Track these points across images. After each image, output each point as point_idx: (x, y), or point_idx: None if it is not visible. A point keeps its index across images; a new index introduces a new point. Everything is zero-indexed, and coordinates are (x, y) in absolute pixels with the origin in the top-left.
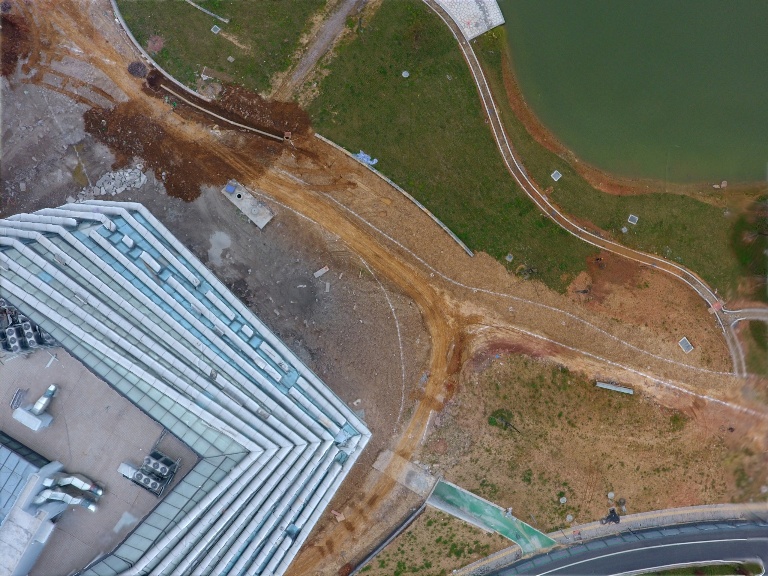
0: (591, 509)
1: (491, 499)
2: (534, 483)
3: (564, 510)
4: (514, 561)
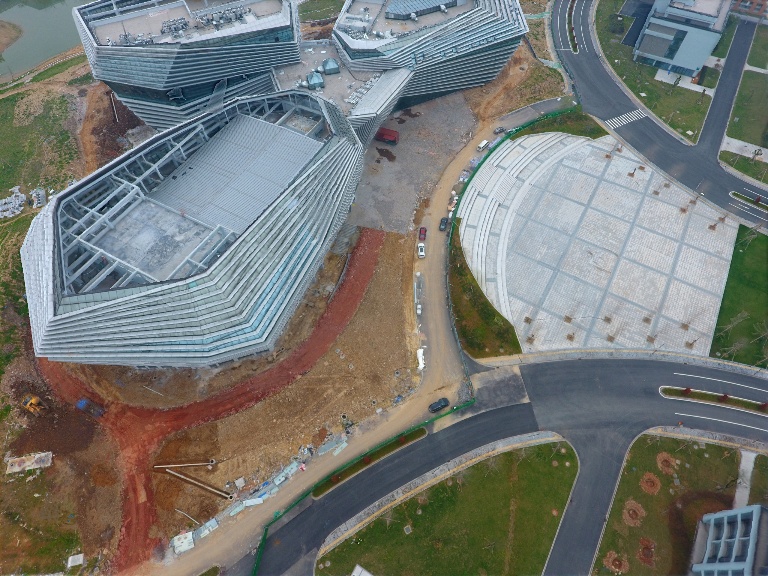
0: (542, 1)
1: (524, 13)
2: (525, 4)
3: (539, 5)
4: (550, 20)
